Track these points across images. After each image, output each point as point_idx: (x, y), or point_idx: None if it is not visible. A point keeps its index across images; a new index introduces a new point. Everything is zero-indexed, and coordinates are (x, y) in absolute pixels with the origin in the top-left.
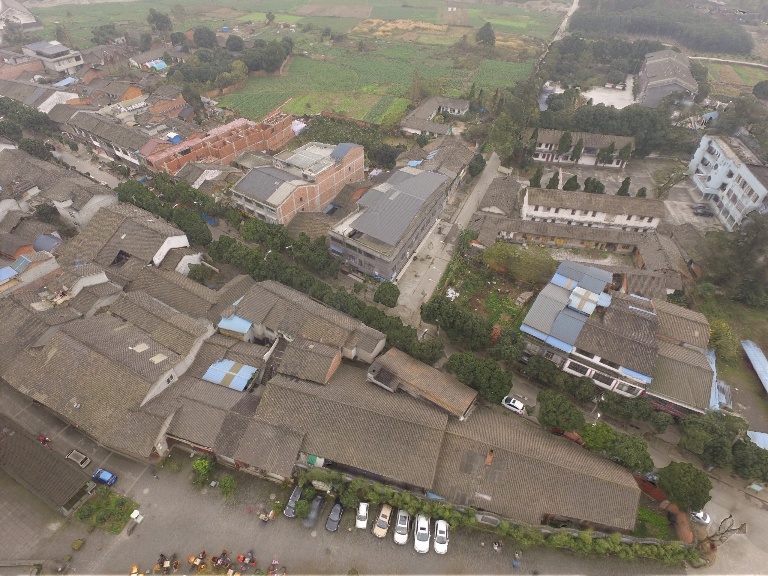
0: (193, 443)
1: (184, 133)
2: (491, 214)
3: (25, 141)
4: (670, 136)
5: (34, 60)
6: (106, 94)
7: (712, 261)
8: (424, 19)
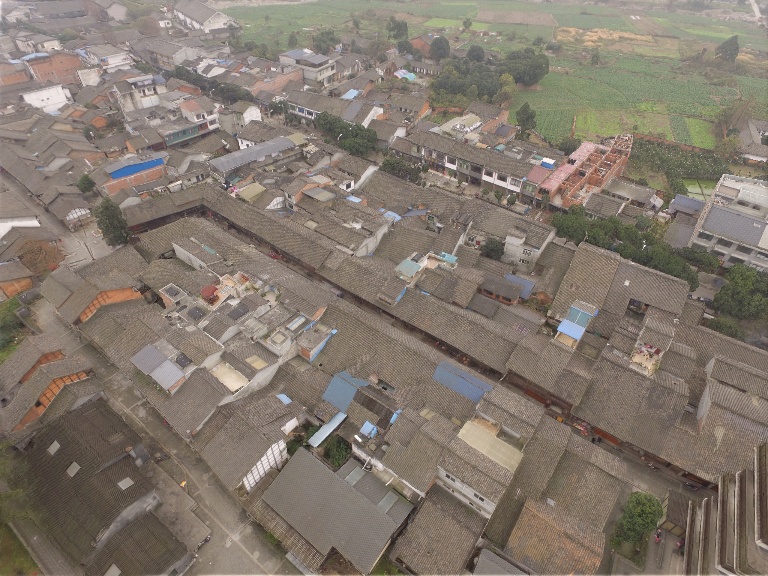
0: None
1: (553, 158)
2: None
3: (392, 163)
4: None
5: (298, 69)
6: (399, 108)
7: None
8: (620, 28)
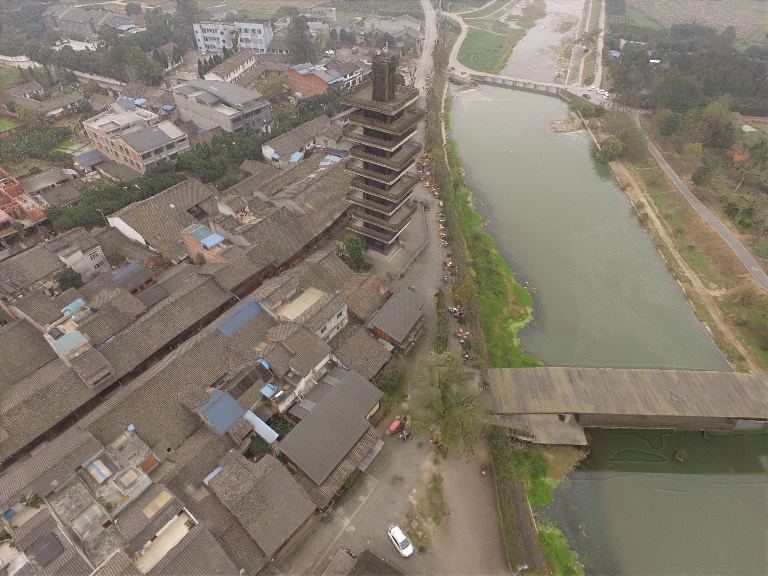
0: None
1: None
2: None
3: None
4: (178, 35)
5: None
6: None
7: (298, 49)
8: None
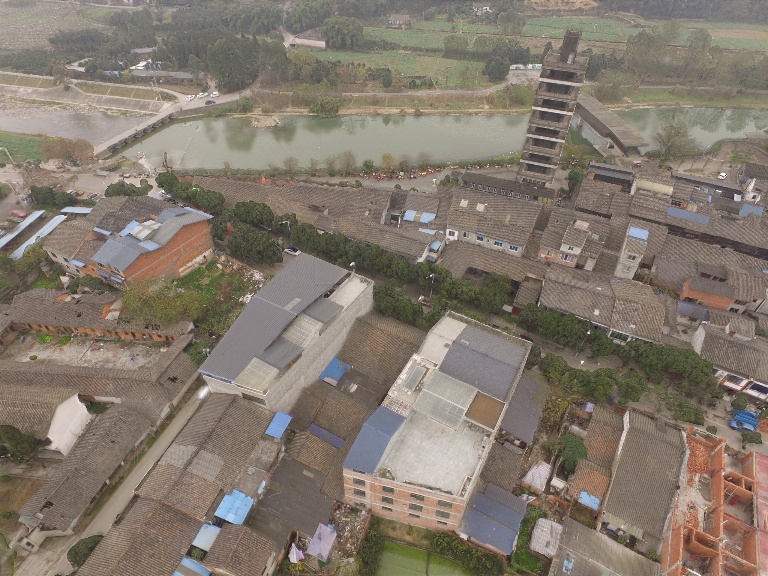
0: (422, 192)
1: None
2: (140, 407)
3: None
4: None
5: None
6: None
7: None
8: None
